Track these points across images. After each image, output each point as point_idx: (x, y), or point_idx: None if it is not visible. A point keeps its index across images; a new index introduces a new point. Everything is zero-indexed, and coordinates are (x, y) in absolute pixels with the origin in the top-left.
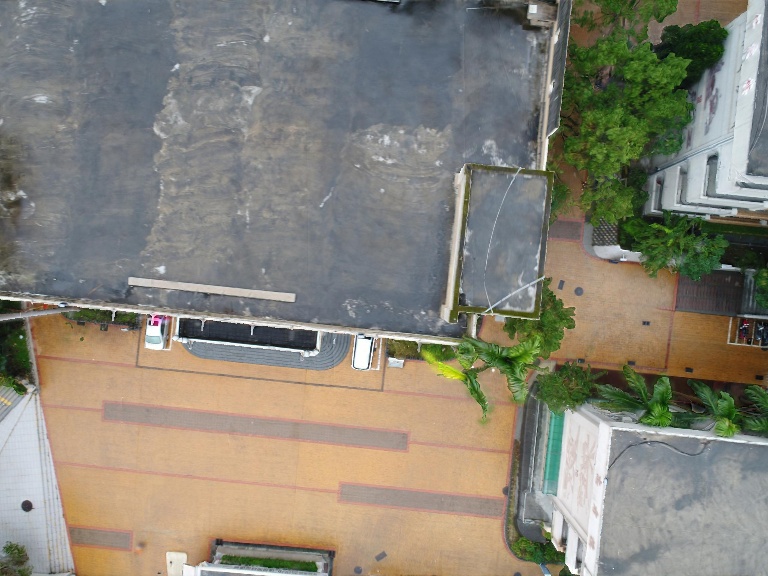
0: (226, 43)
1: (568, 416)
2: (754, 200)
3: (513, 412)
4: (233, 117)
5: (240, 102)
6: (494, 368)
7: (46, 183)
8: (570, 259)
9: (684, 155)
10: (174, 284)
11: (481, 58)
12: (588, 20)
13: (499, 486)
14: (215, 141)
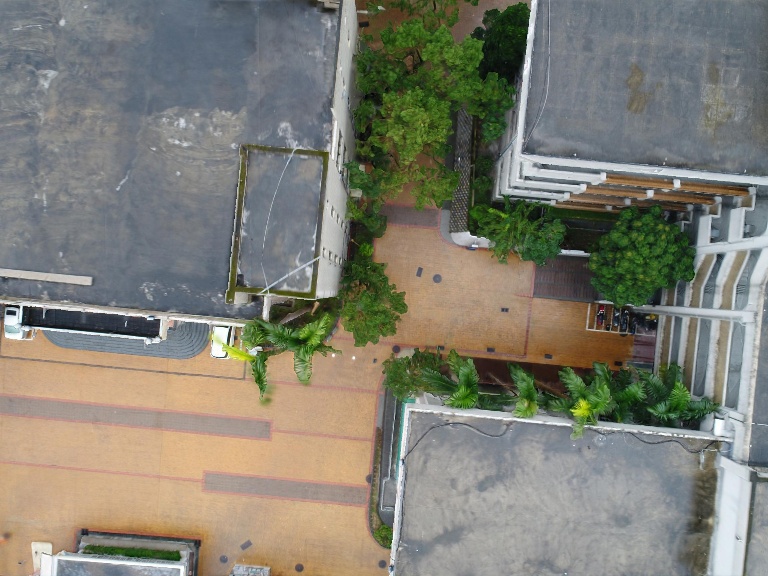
0: (22, 27)
1: (416, 402)
2: (571, 183)
3: (374, 400)
4: (29, 101)
5: (36, 86)
6: (354, 356)
7: None
8: (428, 246)
9: (512, 139)
10: None
11: (276, 40)
12: (406, 4)
13: (362, 474)
14: (11, 125)
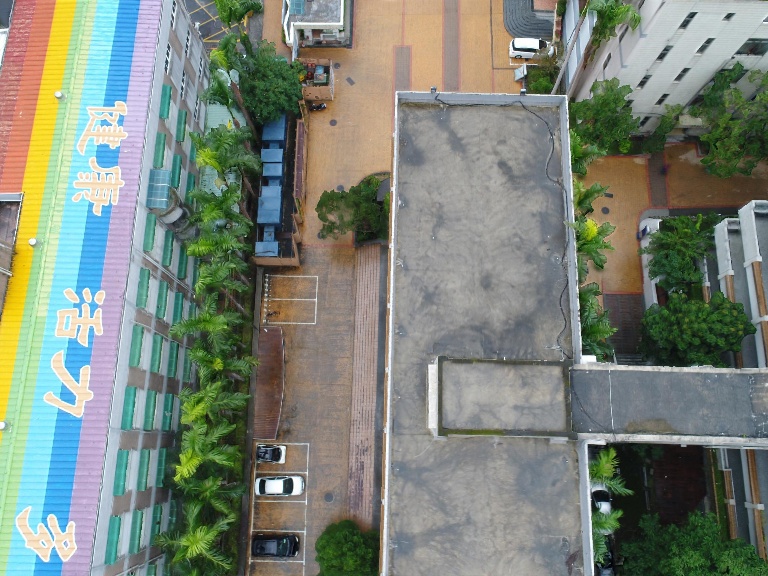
0: None
1: None
2: None
3: None
4: None
5: None
6: None
7: None
8: (633, 200)
9: None
10: None
11: None
12: None
13: None
14: None
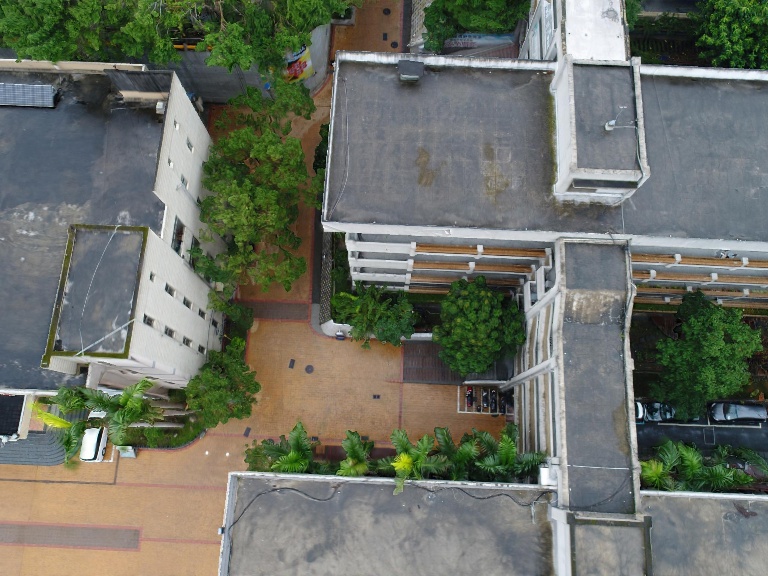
0: None
1: None
2: (400, 259)
3: None
4: None
5: None
6: (228, 452)
7: None
8: (299, 338)
9: None
10: None
11: (121, 146)
12: (251, 121)
13: None
14: None
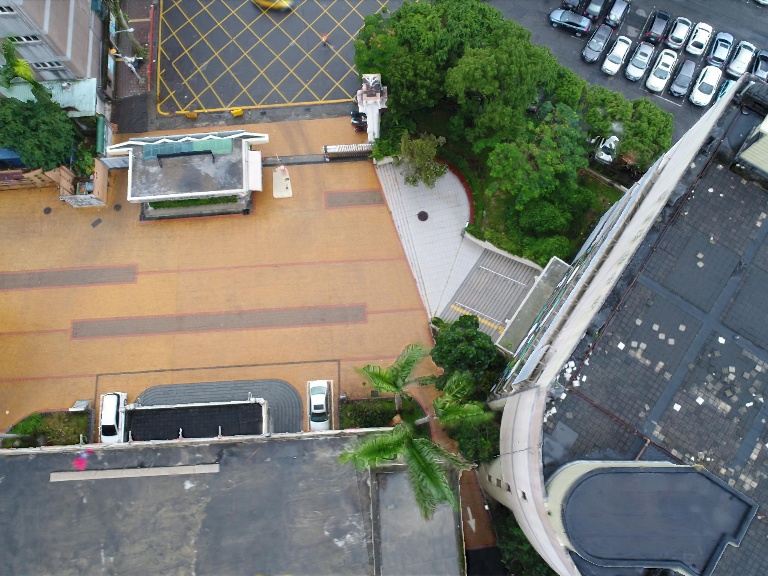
0: None
1: None
2: None
3: None
4: None
5: None
6: None
7: (315, 559)
8: None
9: None
10: (172, 472)
11: None
12: None
13: None
14: None
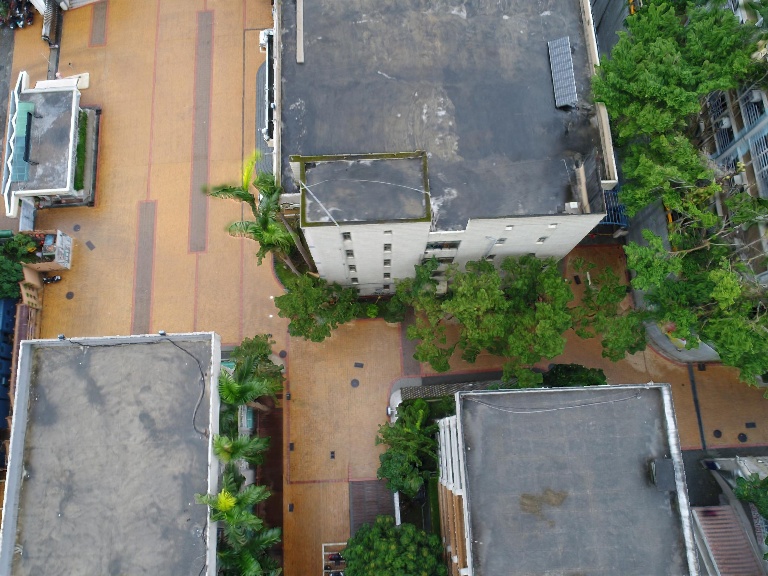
0: None
1: None
2: None
3: (233, 341)
4: (439, 2)
5: (452, 5)
6: (273, 316)
7: None
8: (385, 369)
9: None
10: None
11: (525, 176)
12: (590, 294)
13: None
14: None
